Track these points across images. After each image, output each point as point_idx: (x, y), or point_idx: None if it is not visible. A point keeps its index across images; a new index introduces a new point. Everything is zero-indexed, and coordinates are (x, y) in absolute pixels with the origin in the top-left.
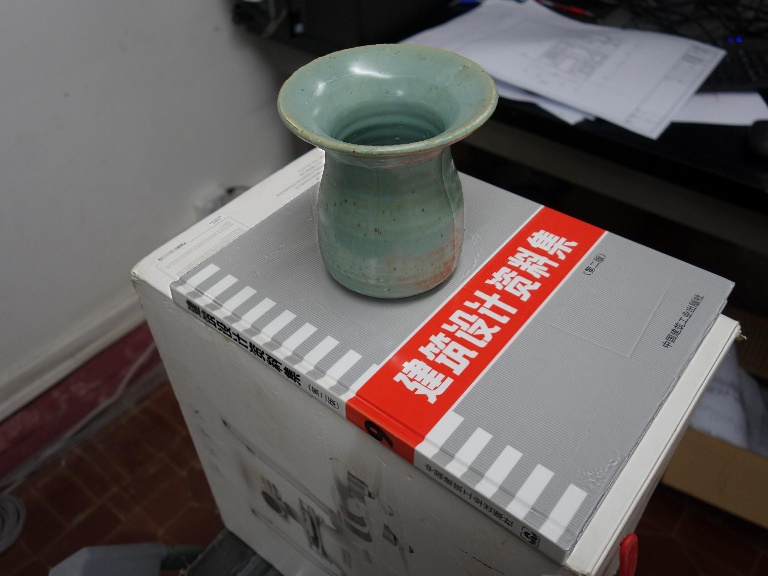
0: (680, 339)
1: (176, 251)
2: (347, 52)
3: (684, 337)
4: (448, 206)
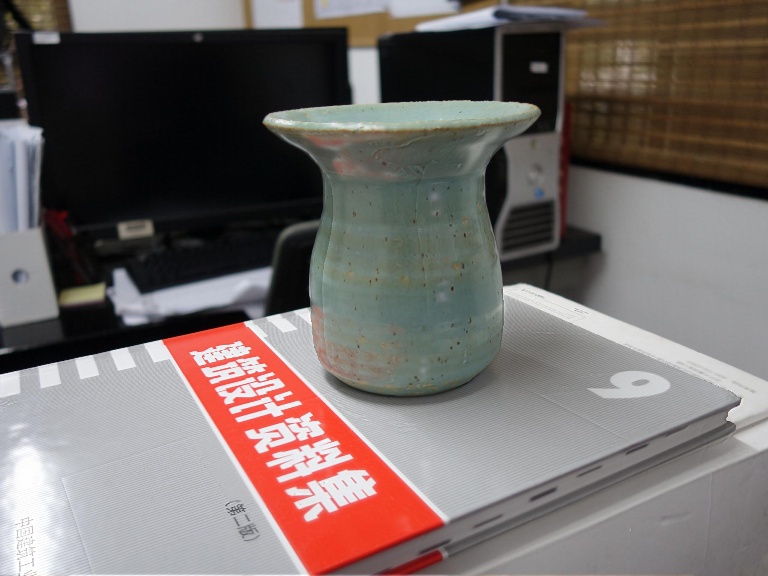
0: (11, 540)
1: (533, 295)
2: (527, 106)
3: (6, 546)
4: (324, 258)
